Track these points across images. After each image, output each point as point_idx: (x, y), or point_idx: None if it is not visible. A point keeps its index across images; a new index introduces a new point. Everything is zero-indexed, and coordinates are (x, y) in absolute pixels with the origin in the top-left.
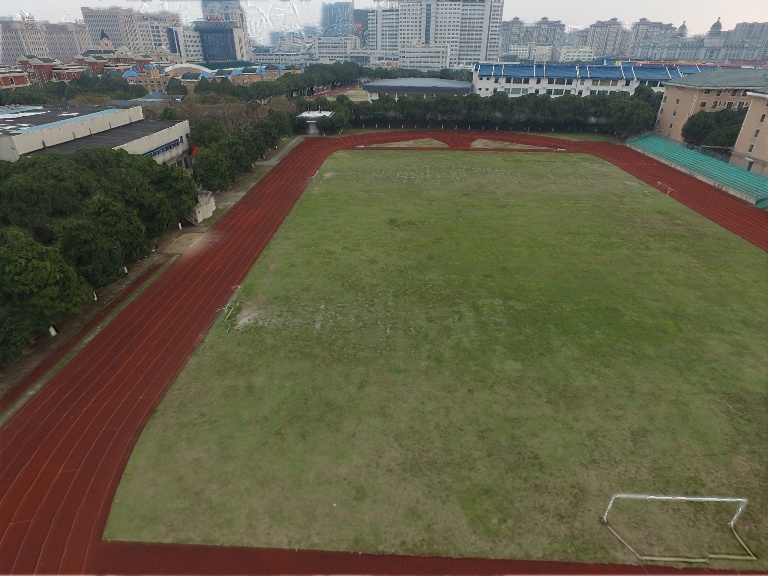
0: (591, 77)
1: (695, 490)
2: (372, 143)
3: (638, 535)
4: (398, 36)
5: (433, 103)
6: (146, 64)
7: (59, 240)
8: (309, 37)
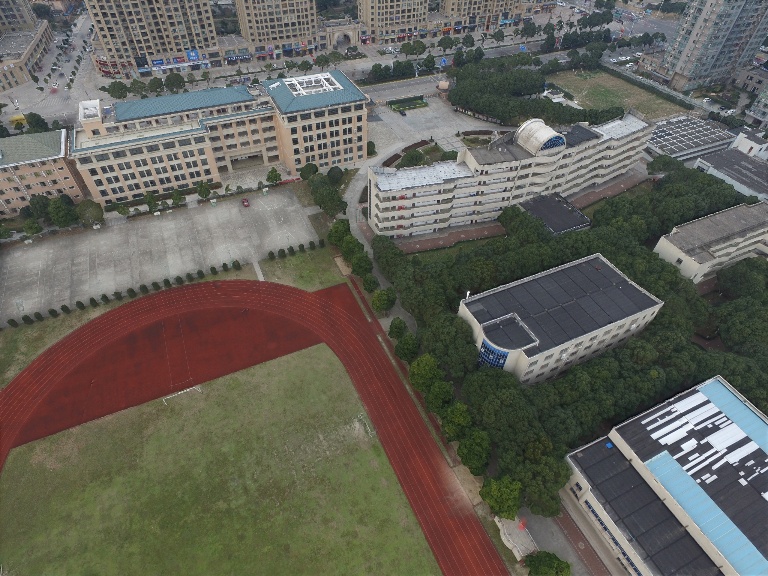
0: None
1: (171, 413)
2: None
3: (193, 393)
4: None
5: None
6: None
7: (439, 381)
8: None
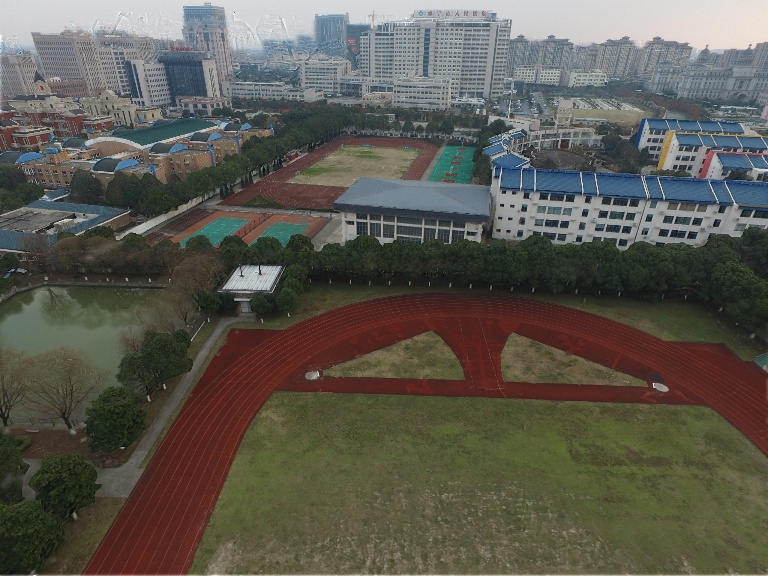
0: (667, 198)
1: None
2: (335, 358)
3: None
4: (393, 62)
5: (436, 258)
6: (78, 121)
7: None
8: (299, 54)
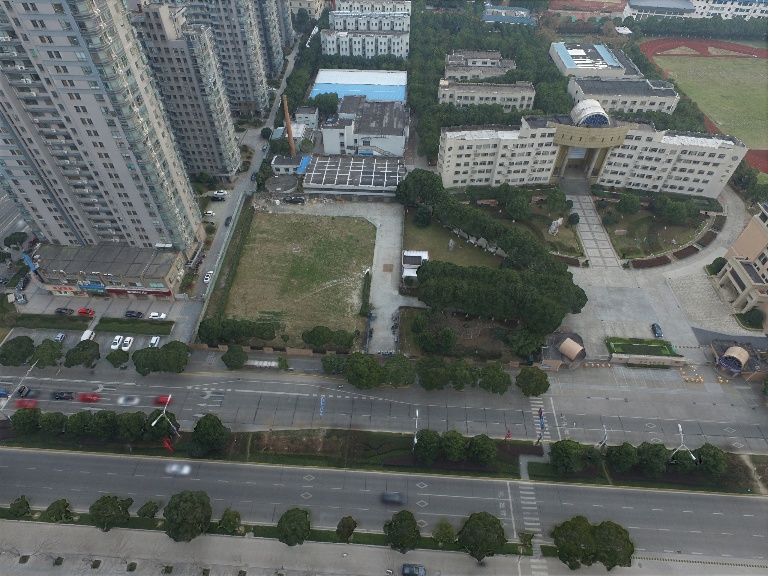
0: (764, 2)
1: None
2: (661, 51)
3: None
4: None
5: (683, 23)
6: None
7: None
8: None
